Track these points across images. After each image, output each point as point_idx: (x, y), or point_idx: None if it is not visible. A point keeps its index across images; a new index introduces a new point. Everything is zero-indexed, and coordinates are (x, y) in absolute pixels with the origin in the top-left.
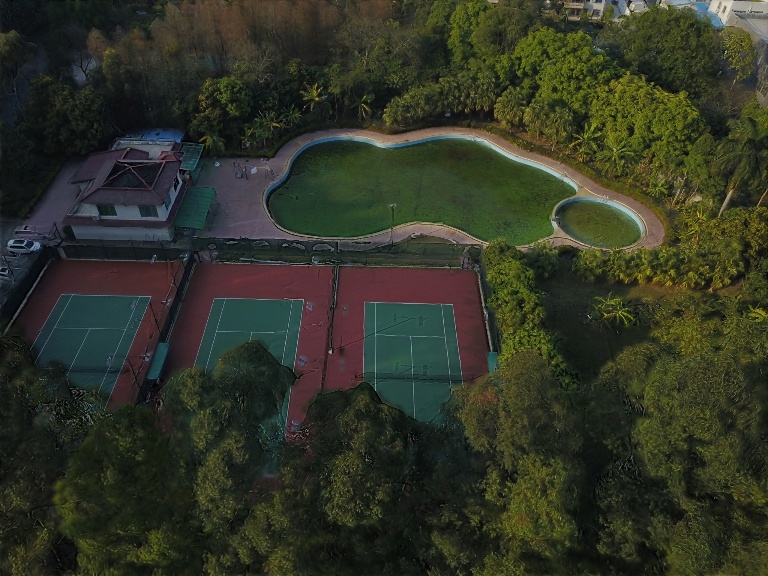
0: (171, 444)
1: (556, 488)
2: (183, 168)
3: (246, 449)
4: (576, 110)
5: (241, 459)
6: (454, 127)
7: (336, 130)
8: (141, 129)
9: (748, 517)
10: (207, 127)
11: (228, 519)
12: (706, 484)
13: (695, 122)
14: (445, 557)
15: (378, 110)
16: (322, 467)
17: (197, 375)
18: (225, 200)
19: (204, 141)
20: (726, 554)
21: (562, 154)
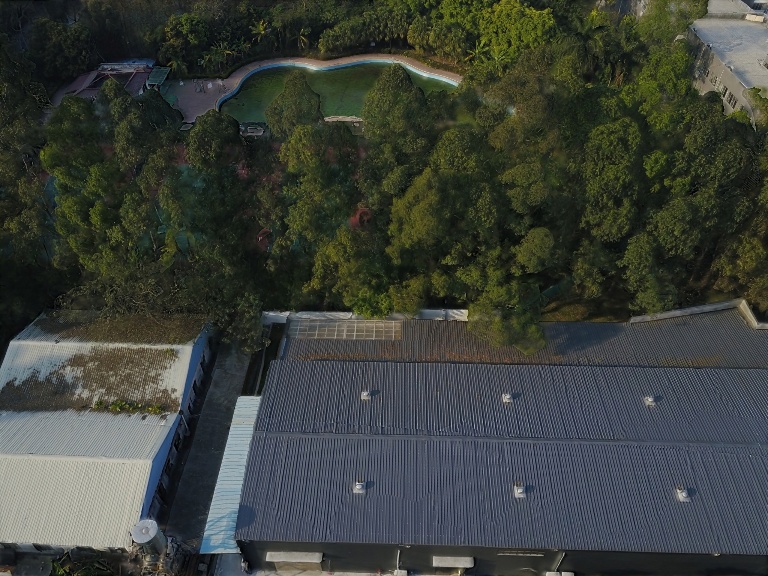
0: (100, 119)
1: (306, 137)
2: (153, 83)
3: (140, 119)
4: (470, 31)
5: (137, 124)
6: (378, 54)
7: (280, 59)
8: (121, 59)
9: (432, 171)
10: (172, 53)
11: (134, 164)
12: (402, 147)
13: (552, 30)
14: (270, 214)
15: (315, 42)
16: (185, 137)
17: (113, 81)
18: (186, 106)
19: (171, 65)
20: (410, 182)
21: (461, 68)
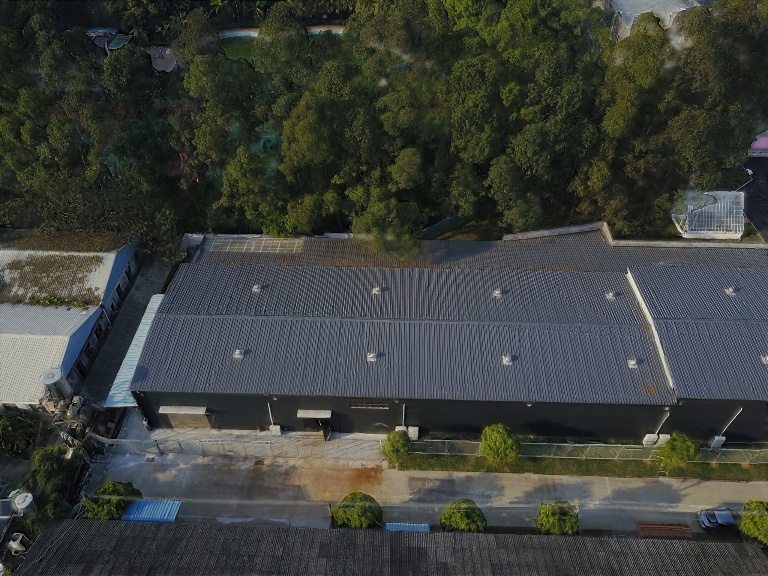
0: (28, 49)
1: (202, 65)
2: None
3: (61, 48)
4: None
5: (58, 52)
6: (330, 25)
7: (238, 29)
8: (87, 27)
9: None
10: (133, 22)
11: (57, 88)
12: (288, 76)
13: None
14: (180, 137)
15: None
16: (101, 66)
17: None
18: None
19: (132, 33)
20: (294, 105)
21: None
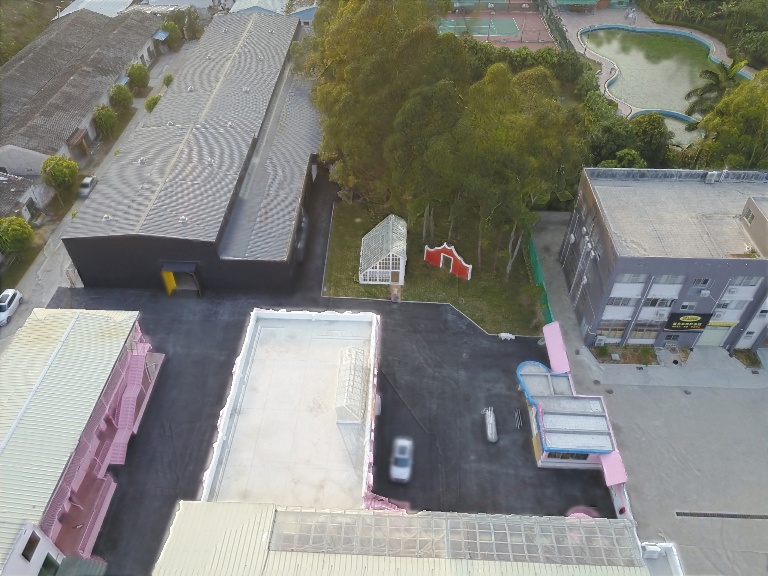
0: None
1: None
2: None
3: None
4: None
5: None
6: None
7: (715, 39)
8: None
9: None
10: None
11: None
12: None
13: None
14: None
15: None
16: None
17: None
18: None
19: None
20: None
21: None
